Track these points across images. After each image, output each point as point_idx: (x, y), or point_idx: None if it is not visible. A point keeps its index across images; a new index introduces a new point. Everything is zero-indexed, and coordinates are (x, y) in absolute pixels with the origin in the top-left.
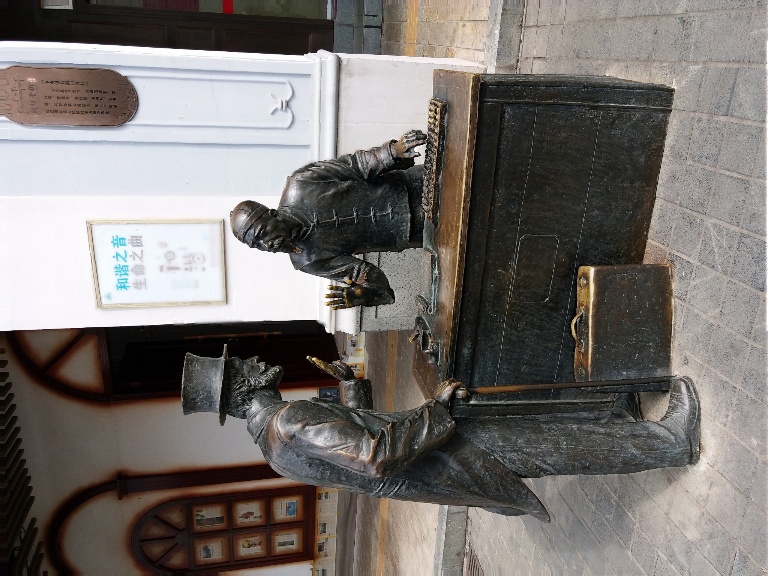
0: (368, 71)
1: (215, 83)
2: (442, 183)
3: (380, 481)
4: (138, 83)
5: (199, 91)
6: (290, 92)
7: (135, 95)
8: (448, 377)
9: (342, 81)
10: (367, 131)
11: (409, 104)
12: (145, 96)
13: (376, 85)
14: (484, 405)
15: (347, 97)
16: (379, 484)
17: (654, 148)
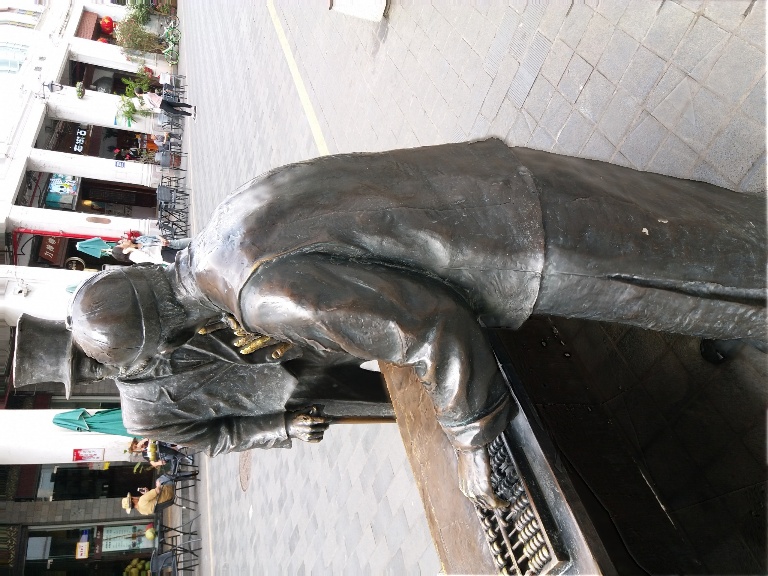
0: None
1: None
2: None
3: None
4: None
5: None
6: None
7: None
8: None
9: None
10: None
11: None
12: None
13: None
14: None
15: None
16: None
17: (690, 571)
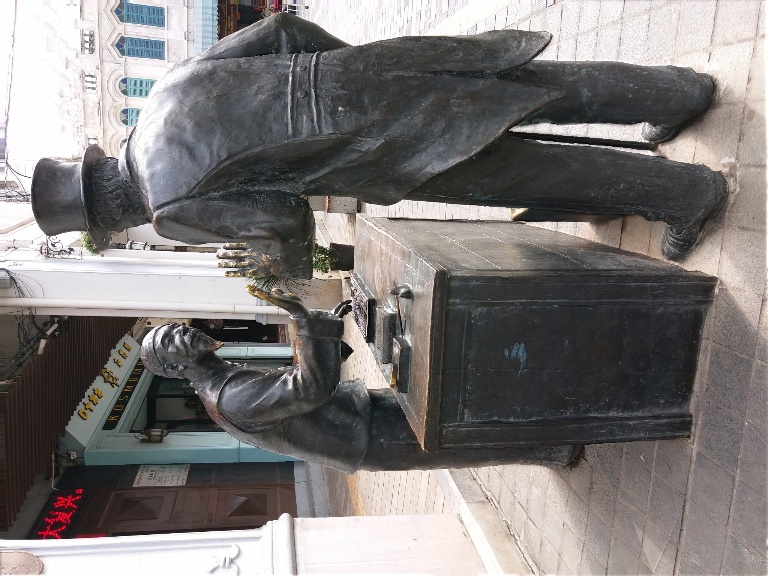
0: (327, 527)
1: (145, 553)
2: (367, 281)
3: (291, 54)
4: (50, 561)
5: (123, 561)
6: (236, 552)
7: (40, 569)
8: (418, 253)
9: (297, 529)
10: (336, 571)
11: (383, 544)
12: (52, 569)
13: (339, 536)
14: (495, 270)
15: (305, 544)
16: (291, 56)
17: None
